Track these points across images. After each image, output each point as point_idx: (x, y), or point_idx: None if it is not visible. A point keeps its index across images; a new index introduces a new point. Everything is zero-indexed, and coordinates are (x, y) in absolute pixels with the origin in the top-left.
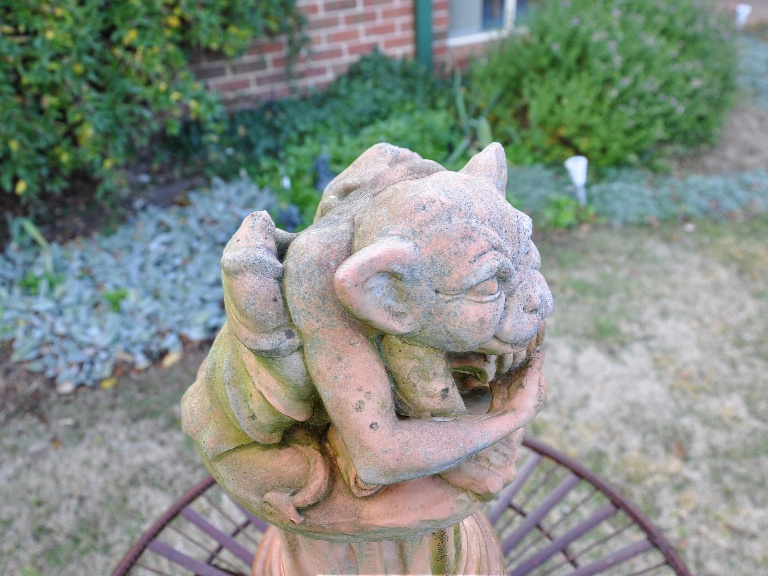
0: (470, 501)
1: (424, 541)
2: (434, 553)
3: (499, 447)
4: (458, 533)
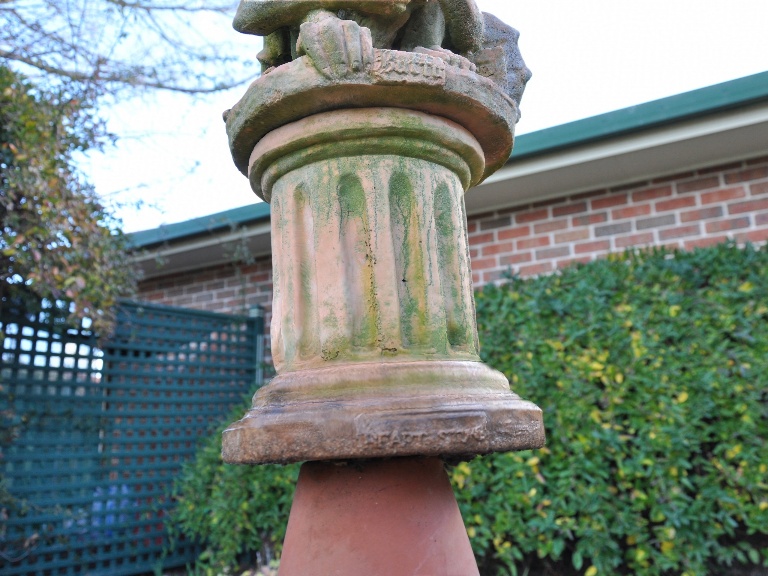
0: (302, 62)
1: (332, 219)
2: (367, 291)
3: (338, 19)
4: (428, 323)
